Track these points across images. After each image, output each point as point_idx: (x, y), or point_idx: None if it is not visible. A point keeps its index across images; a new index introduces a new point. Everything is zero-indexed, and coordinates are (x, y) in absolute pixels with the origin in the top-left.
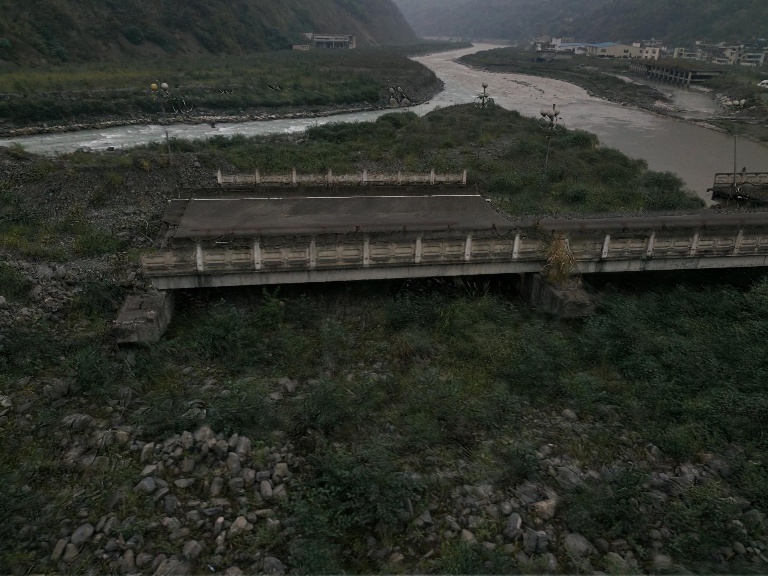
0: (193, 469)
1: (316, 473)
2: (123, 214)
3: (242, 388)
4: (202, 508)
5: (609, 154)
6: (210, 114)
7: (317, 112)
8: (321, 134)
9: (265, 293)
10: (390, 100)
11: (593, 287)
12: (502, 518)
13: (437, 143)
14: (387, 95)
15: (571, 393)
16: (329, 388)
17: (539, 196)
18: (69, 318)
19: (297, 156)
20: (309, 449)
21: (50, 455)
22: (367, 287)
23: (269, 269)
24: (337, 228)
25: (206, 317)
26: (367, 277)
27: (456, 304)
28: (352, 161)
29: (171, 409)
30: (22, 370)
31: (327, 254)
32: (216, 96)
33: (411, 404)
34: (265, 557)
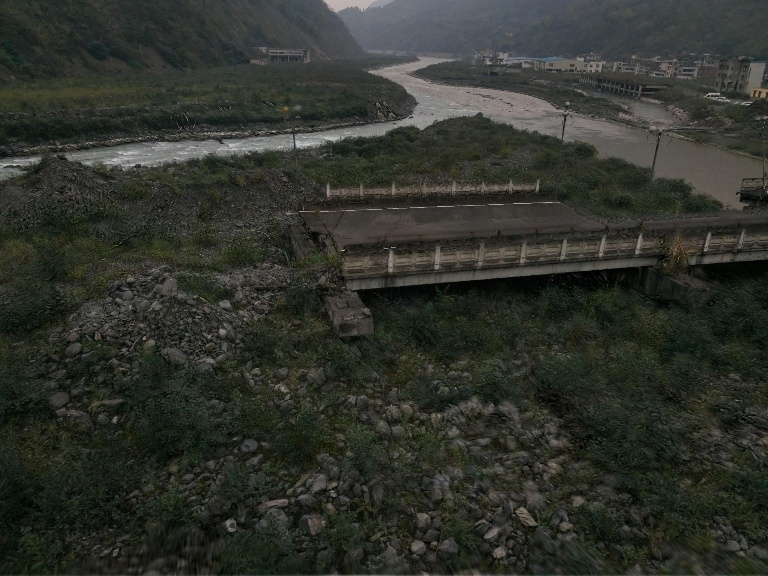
0: (480, 432)
1: (582, 429)
2: (236, 227)
3: (464, 370)
4: (503, 461)
5: (619, 163)
6: (213, 130)
7: (313, 127)
8: (345, 149)
9: (438, 291)
10: (378, 114)
11: (703, 276)
12: (739, 453)
13: (465, 156)
14: (374, 110)
15: (728, 361)
16: (532, 367)
17: (584, 202)
18: (278, 318)
19: (344, 170)
20: (562, 412)
21: (347, 429)
22: (514, 283)
23: (445, 269)
24: (468, 233)
25: (395, 313)
26: (518, 274)
27: (596, 295)
28: (397, 174)
29: (417, 389)
30: (275, 363)
31: (491, 255)
32: (216, 112)
33: (606, 376)
34: (582, 491)
